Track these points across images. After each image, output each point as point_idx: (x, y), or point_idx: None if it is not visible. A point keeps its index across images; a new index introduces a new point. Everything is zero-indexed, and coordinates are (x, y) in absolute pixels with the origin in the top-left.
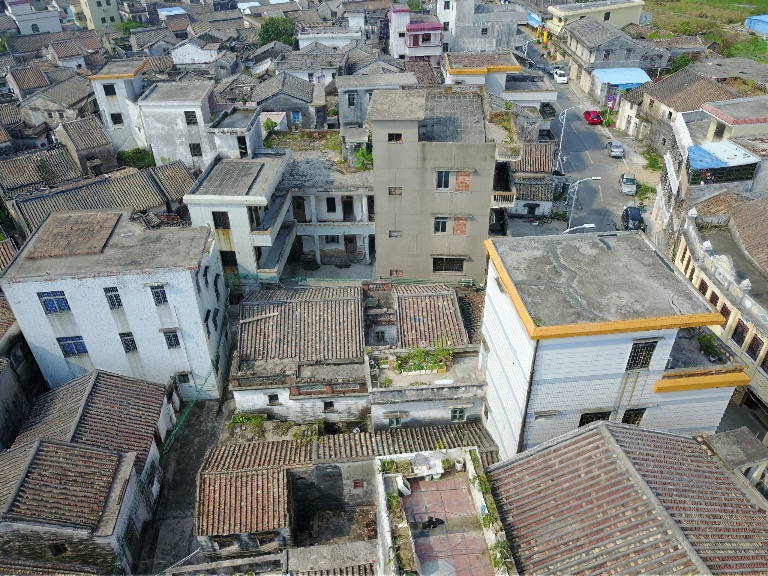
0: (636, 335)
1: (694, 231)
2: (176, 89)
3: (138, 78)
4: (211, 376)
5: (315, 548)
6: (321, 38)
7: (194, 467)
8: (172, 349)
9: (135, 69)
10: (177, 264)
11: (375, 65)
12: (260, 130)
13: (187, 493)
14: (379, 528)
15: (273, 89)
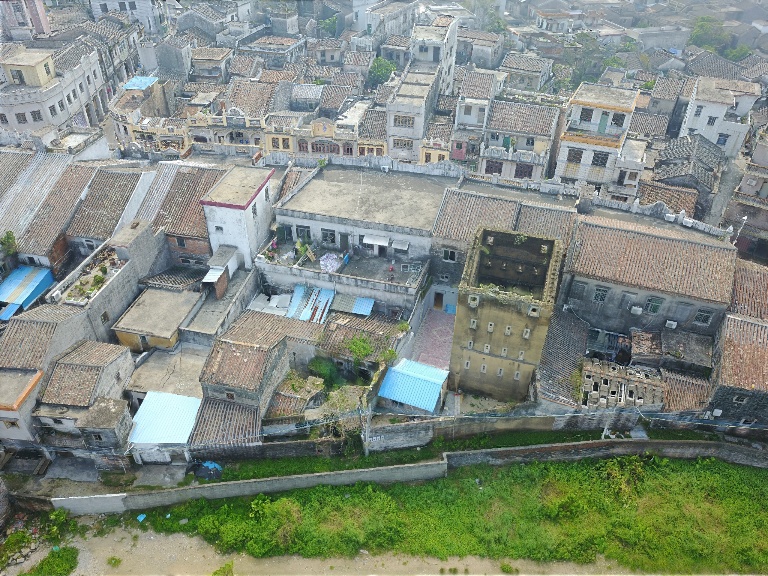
0: None
1: None
2: None
3: None
4: None
5: None
6: None
7: None
8: None
9: None
10: None
11: None
12: None
13: None
14: None
15: None
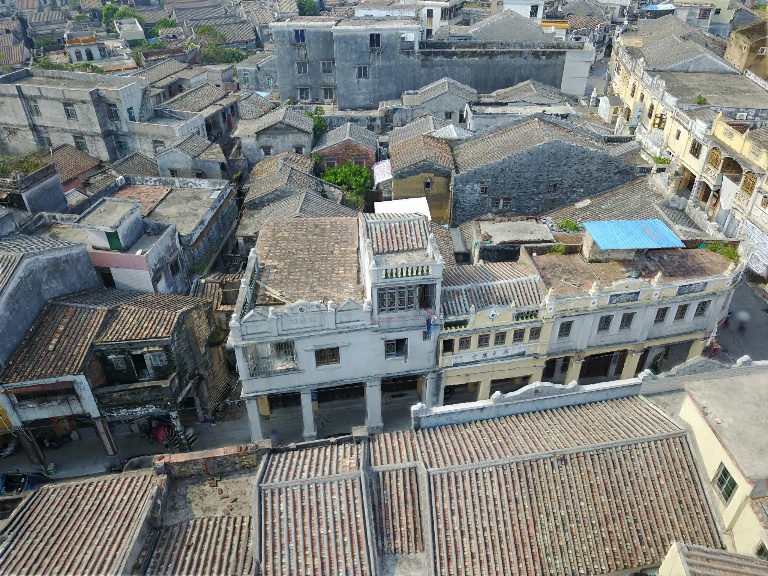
0: (532, 2)
1: None
2: None
3: None
4: None
5: None
6: None
7: None
8: None
9: None
10: None
11: None
12: None
13: None
14: None
15: None
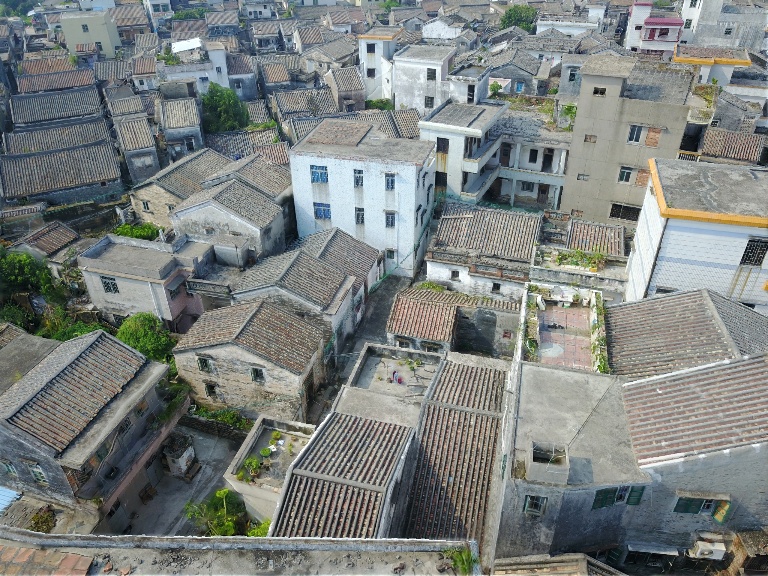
0: (752, 232)
1: None
2: (424, 51)
3: (394, 42)
4: (411, 257)
5: (467, 355)
6: (558, 25)
7: (386, 314)
8: (388, 228)
9: (394, 33)
10: (408, 160)
11: (605, 53)
12: (487, 85)
13: (379, 327)
14: None
15: (504, 60)
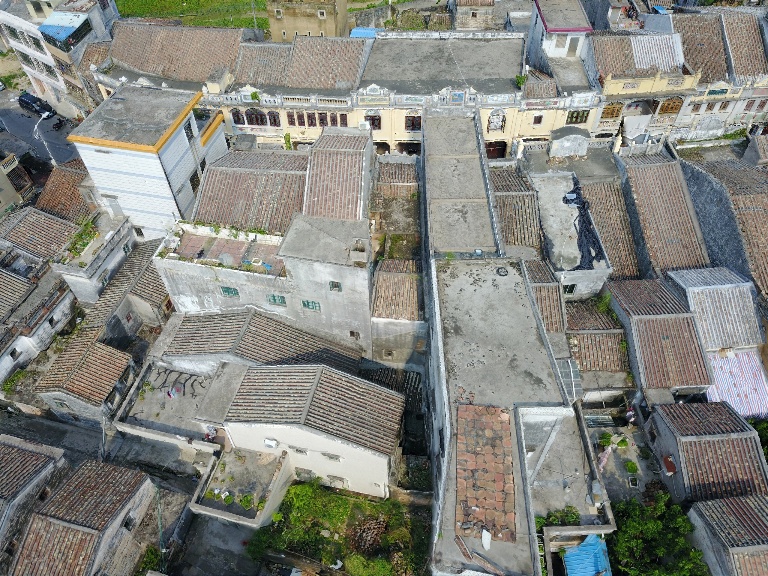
0: (182, 123)
1: (106, 77)
2: None
3: None
4: None
5: (157, 342)
6: None
7: None
8: None
9: None
10: None
11: None
12: None
13: None
14: (178, 291)
15: None
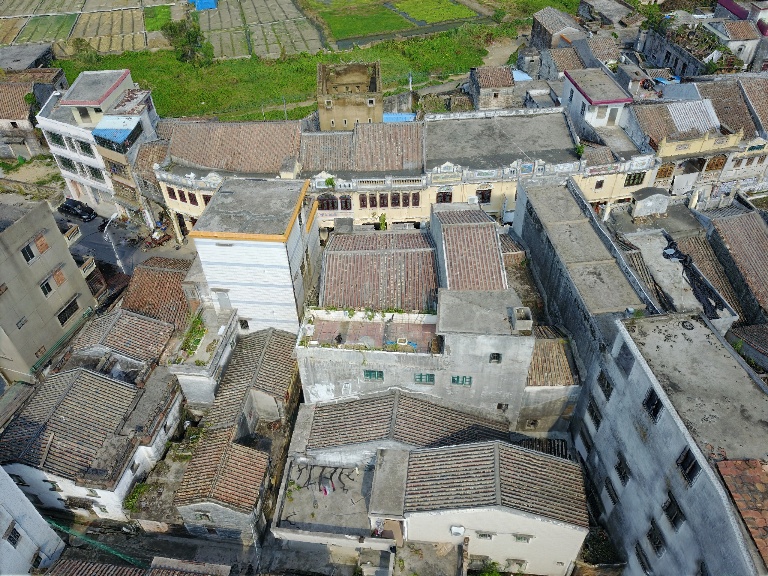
0: None
1: (172, 175)
2: None
3: None
4: (52, 533)
5: (293, 437)
6: None
7: None
8: (17, 546)
9: None
10: None
11: None
12: None
13: None
14: (315, 380)
15: None
